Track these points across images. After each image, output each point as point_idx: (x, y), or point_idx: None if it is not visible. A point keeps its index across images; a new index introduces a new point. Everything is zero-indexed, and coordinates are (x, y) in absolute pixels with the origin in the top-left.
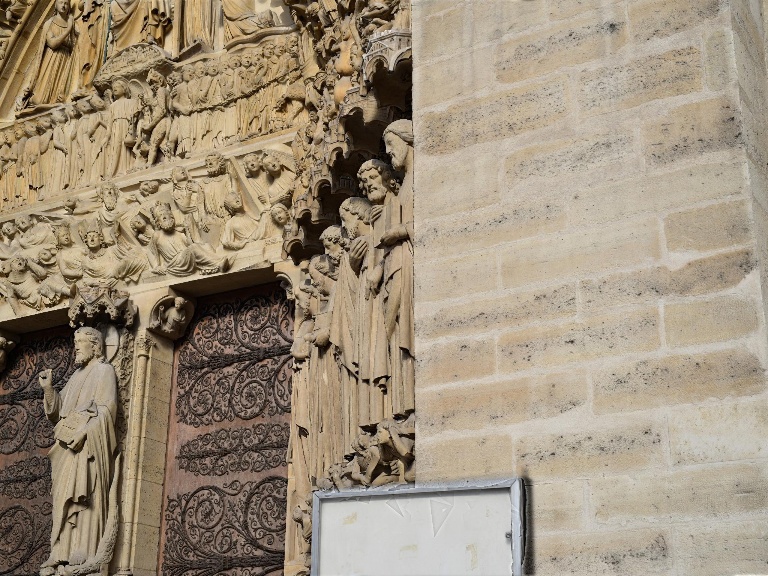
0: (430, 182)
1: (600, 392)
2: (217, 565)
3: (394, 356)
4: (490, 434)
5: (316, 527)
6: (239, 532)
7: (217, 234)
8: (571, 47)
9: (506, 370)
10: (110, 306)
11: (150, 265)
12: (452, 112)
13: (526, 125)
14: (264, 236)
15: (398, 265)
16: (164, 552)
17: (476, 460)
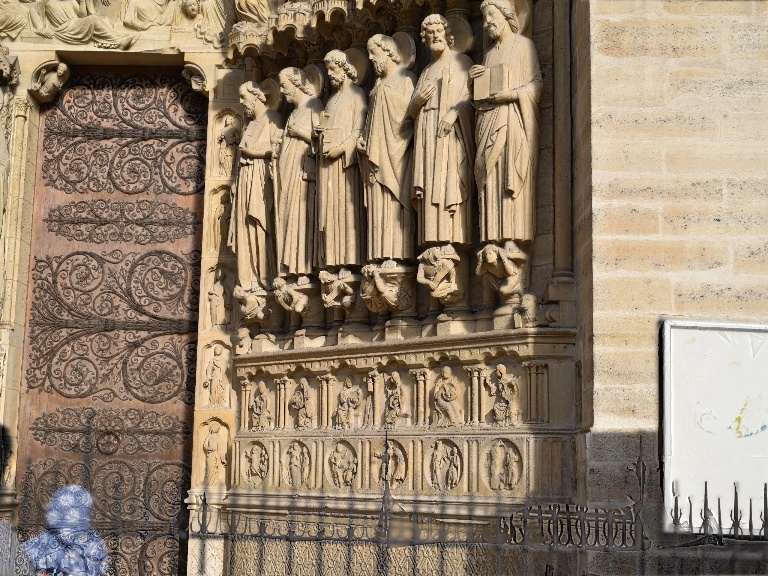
0: (606, 77)
1: (739, 258)
2: (97, 326)
3: (491, 193)
4: (655, 277)
5: (668, 344)
6: (122, 298)
7: (117, 10)
8: (725, 0)
9: (668, 233)
10: (4, 63)
11: (32, 25)
12: (626, 25)
13: (688, 51)
14: (171, 23)
15: (505, 121)
16: (32, 309)
17: (643, 294)
